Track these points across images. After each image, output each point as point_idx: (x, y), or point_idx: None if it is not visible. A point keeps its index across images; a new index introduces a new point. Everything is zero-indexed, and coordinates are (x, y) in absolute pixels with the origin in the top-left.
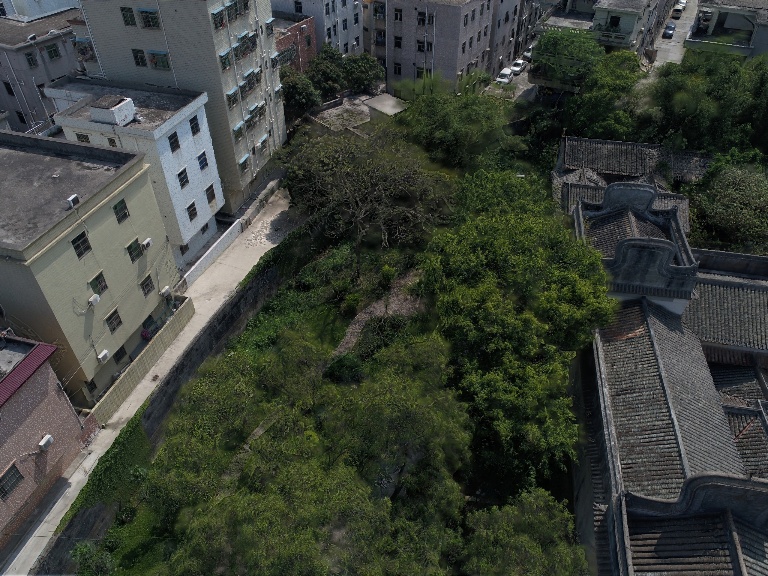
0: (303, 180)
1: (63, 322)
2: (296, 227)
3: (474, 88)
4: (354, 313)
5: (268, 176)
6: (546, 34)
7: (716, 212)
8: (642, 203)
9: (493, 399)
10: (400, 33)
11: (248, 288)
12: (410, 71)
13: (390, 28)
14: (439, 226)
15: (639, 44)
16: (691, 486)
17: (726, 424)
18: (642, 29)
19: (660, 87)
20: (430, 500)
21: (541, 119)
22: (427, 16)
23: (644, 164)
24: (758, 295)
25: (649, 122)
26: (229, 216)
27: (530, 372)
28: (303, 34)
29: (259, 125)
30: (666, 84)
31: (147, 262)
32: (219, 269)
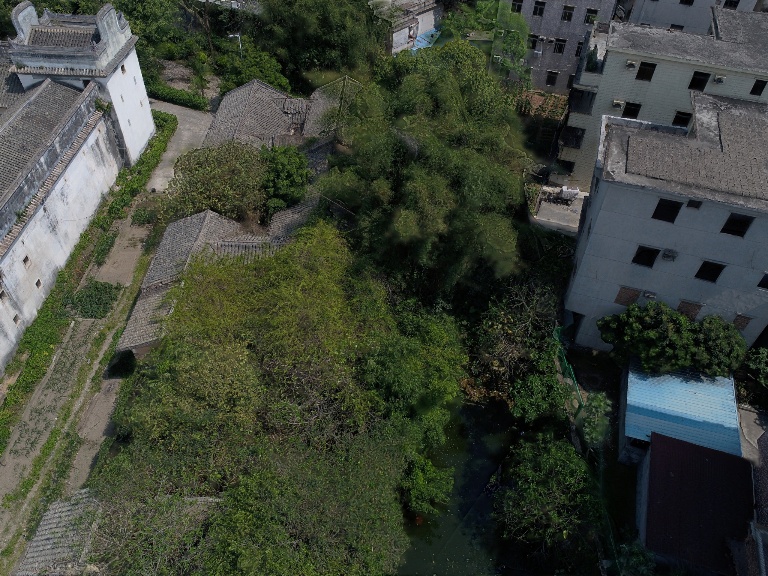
0: None
1: None
2: None
3: (554, 79)
4: (171, 59)
5: None
6: None
7: None
8: None
9: None
10: None
11: None
12: None
13: None
14: None
15: None
16: None
17: None
18: None
19: None
20: None
21: None
22: None
23: None
24: None
25: None
26: None
27: None
28: None
29: None
30: None
31: None
32: None
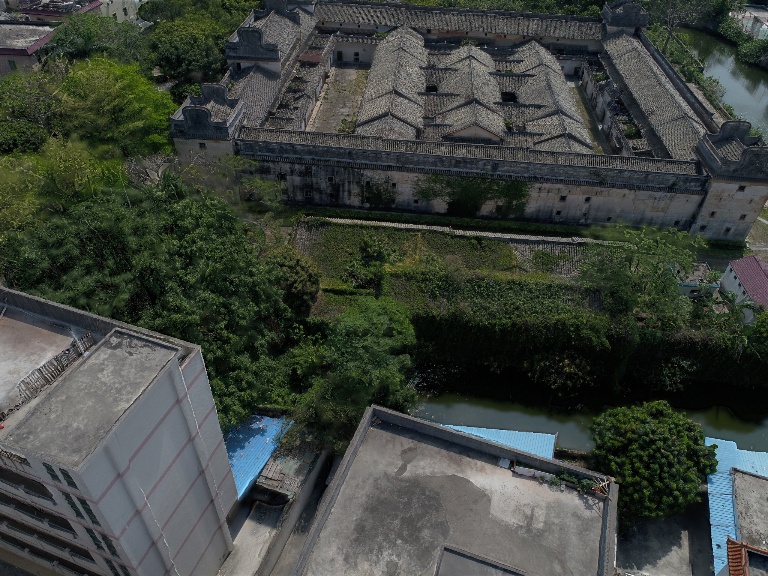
0: None
1: (100, 6)
2: None
3: None
4: None
5: None
6: None
7: None
8: None
9: (231, 5)
10: None
11: None
12: None
13: None
14: None
15: None
16: (265, 2)
17: (311, 29)
18: None
19: None
20: (207, 11)
21: None
22: None
23: None
24: (340, 7)
25: None
26: None
27: (242, 0)
28: None
29: None
30: None
31: (125, 2)
32: None
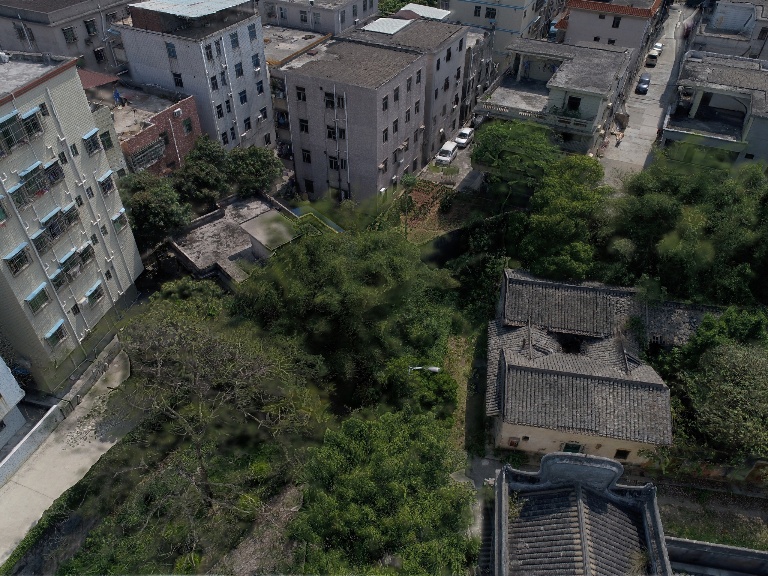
0: (140, 356)
1: None
2: (127, 427)
3: None
4: None
5: (120, 319)
6: (490, 115)
7: (709, 419)
8: (600, 480)
9: None
10: (305, 115)
11: (16, 570)
12: (321, 160)
13: (293, 109)
14: (338, 401)
15: (607, 117)
16: None
17: None
18: (609, 105)
19: (630, 210)
20: None
21: (481, 233)
22: (336, 98)
23: (610, 320)
24: None
25: (617, 251)
26: (47, 395)
27: None
28: (179, 119)
29: (84, 273)
30: (638, 206)
31: None
32: (11, 496)
